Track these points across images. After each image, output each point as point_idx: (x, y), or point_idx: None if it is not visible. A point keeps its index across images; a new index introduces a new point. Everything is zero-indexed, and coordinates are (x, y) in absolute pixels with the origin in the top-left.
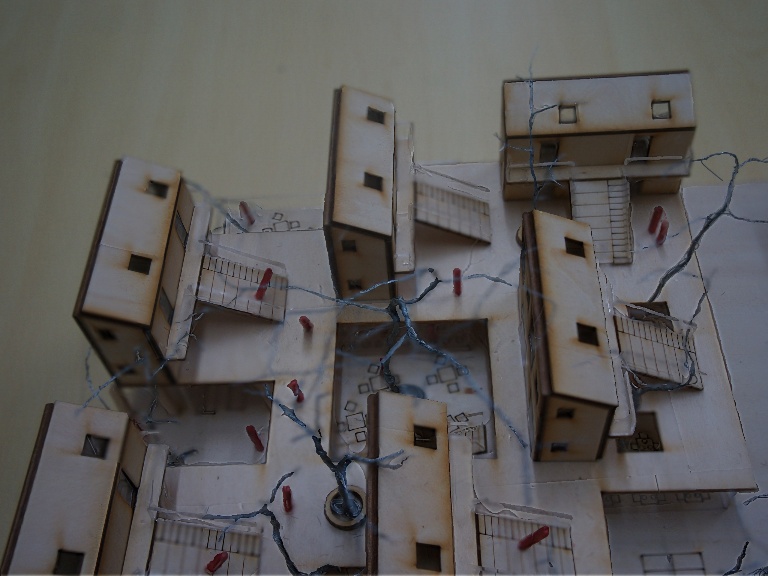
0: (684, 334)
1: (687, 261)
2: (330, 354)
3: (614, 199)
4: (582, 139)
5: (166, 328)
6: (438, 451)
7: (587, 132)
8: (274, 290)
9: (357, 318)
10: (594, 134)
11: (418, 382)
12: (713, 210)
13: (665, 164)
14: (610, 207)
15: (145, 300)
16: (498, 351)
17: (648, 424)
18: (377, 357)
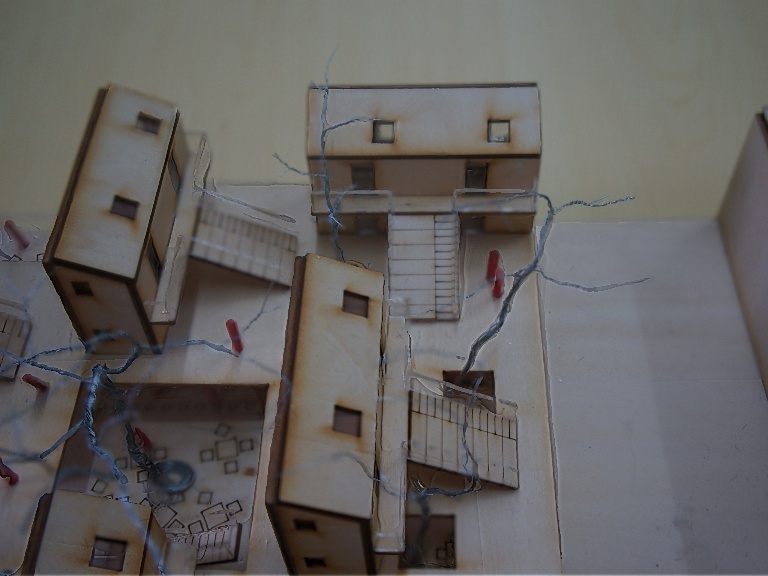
0: (504, 415)
1: (499, 326)
2: (64, 423)
3: (441, 239)
4: (401, 163)
5: None
6: (123, 574)
7: (406, 155)
8: (9, 337)
9: None
10: (415, 158)
11: (189, 458)
12: (585, 253)
13: None
14: (436, 249)
15: None
16: None
17: (446, 530)
18: (144, 423)
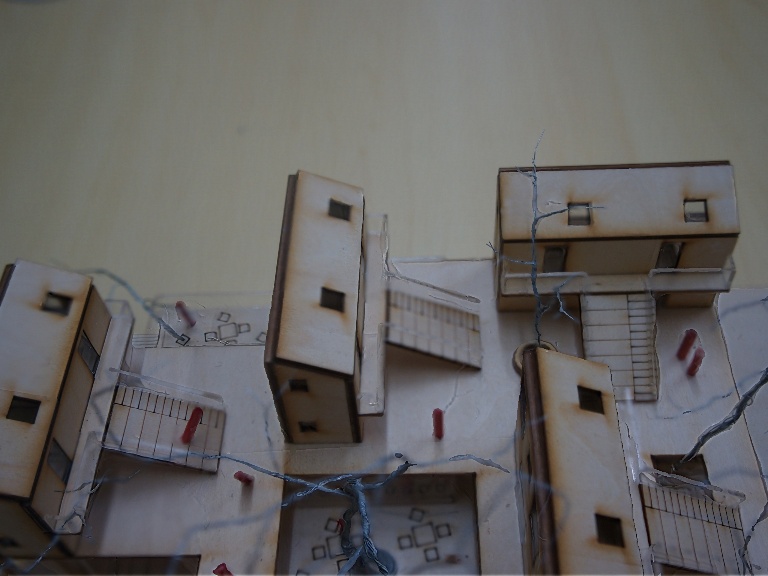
0: (728, 504)
1: (736, 419)
2: (274, 518)
3: (635, 318)
4: (596, 245)
5: (58, 490)
6: None
7: (603, 237)
8: (207, 428)
9: (310, 468)
10: (612, 239)
11: (387, 545)
12: (750, 321)
13: (698, 275)
14: (630, 329)
15: (26, 461)
16: (489, 519)
17: None
18: (337, 509)
